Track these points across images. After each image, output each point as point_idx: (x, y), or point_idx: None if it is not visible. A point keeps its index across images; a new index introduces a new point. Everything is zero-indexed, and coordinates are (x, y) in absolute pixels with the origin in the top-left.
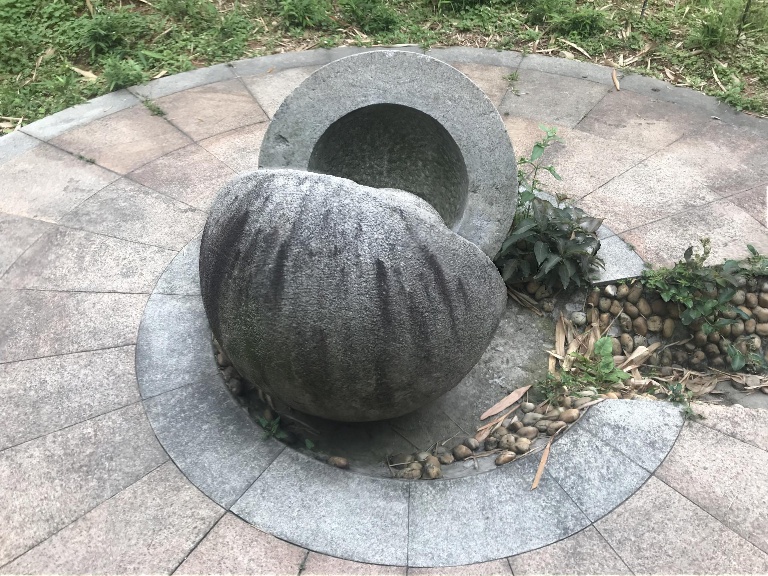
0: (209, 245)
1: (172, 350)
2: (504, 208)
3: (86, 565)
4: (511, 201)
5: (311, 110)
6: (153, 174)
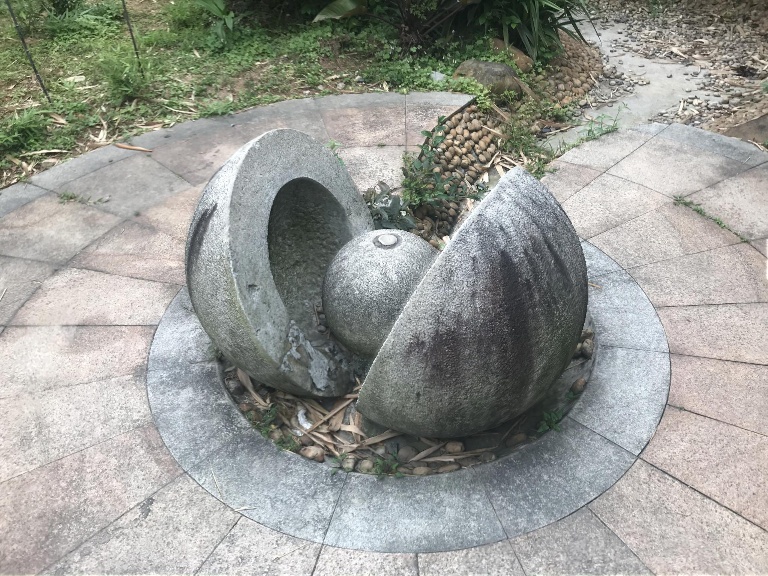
0: (484, 320)
1: (432, 513)
2: (365, 212)
3: (714, 568)
4: (364, 203)
5: (250, 240)
6: (6, 565)
